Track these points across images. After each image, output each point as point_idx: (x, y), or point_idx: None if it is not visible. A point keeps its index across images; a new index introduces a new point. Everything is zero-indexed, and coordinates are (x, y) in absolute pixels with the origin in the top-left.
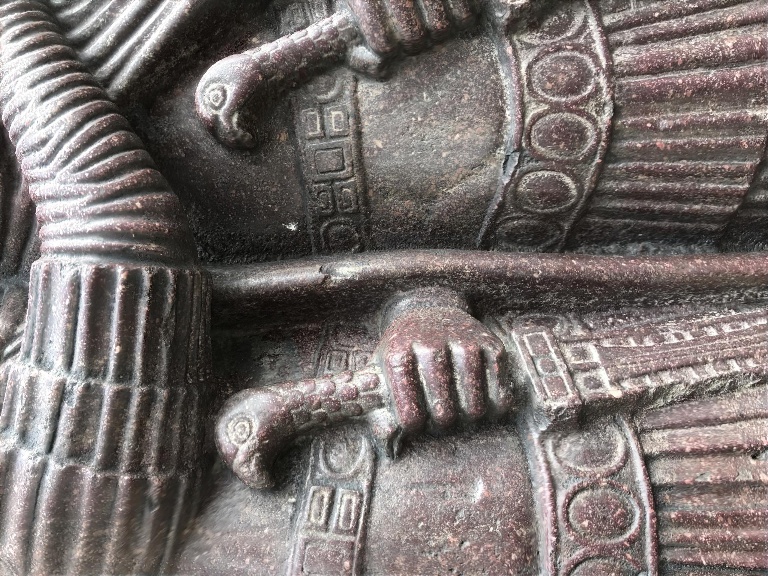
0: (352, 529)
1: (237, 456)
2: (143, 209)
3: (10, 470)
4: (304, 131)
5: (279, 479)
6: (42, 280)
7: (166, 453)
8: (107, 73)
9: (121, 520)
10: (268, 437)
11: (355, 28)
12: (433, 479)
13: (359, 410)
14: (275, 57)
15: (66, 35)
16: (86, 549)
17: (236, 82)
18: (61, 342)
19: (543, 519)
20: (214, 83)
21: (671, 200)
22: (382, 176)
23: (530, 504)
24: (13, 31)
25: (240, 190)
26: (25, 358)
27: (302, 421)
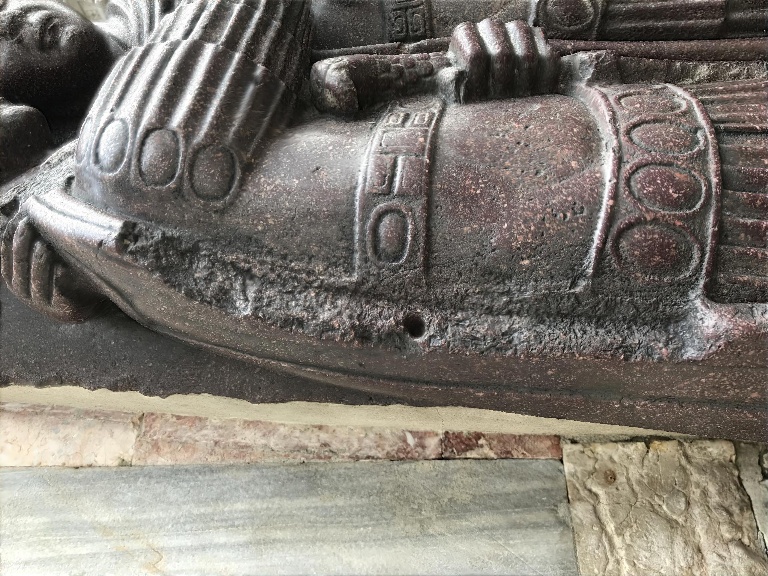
0: (426, 123)
1: (331, 67)
2: None
3: (150, 55)
4: None
5: (361, 116)
6: None
7: (272, 67)
8: None
9: (232, 80)
10: (356, 65)
11: None
12: None
13: (431, 67)
14: None
15: None
16: (198, 98)
17: None
18: None
19: (598, 110)
20: None
21: (669, 18)
22: (444, 7)
23: (585, 109)
24: None
25: (336, 26)
26: None
27: (384, 68)
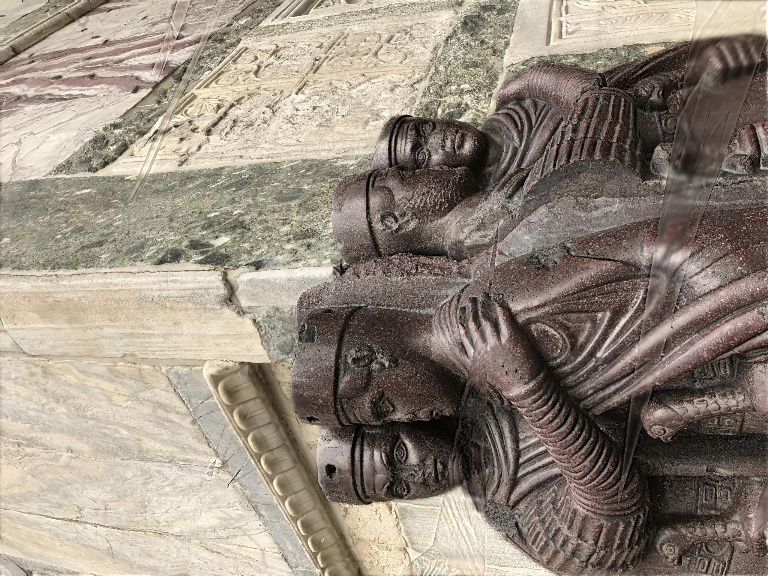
0: (720, 575)
1: (668, 559)
2: (628, 497)
3: (569, 561)
4: (706, 423)
5: None
6: (582, 519)
7: None
8: (589, 407)
9: None
10: None
11: (753, 410)
12: (764, 562)
13: None
14: (698, 418)
15: (560, 384)
16: None
17: (672, 428)
18: (593, 538)
19: None
20: (658, 425)
21: None
22: None
23: None
24: (548, 418)
25: None
26: (569, 528)
27: None
